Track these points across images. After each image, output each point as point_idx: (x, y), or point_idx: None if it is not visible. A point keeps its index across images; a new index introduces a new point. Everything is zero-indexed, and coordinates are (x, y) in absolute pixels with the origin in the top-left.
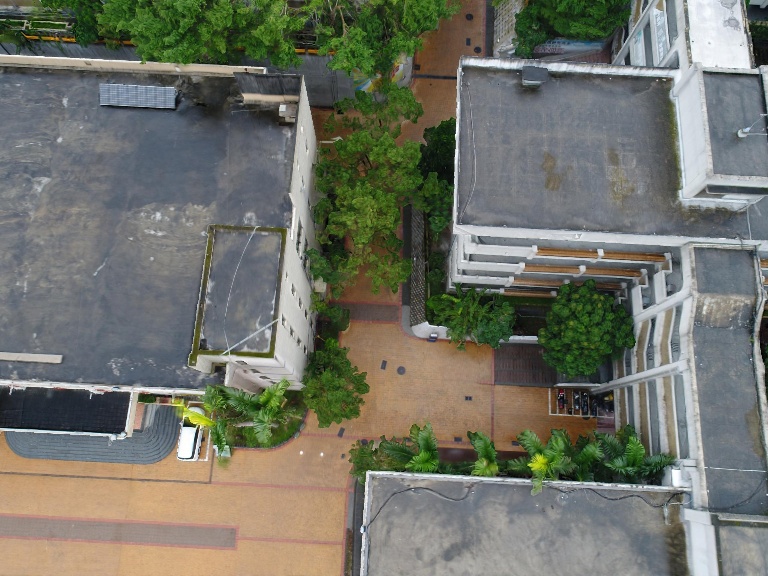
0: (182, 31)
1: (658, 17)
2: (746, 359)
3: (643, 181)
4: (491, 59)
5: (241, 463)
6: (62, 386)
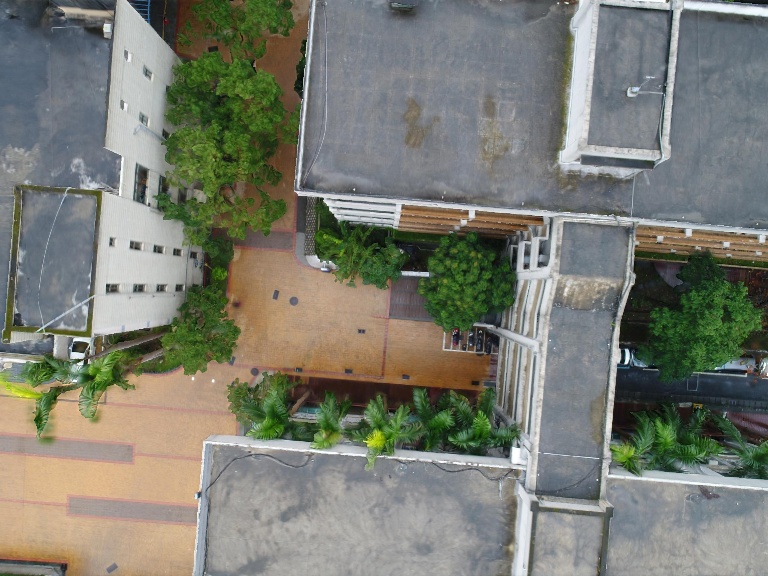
0: None
1: None
2: (604, 344)
3: (520, 138)
4: None
5: None
6: None
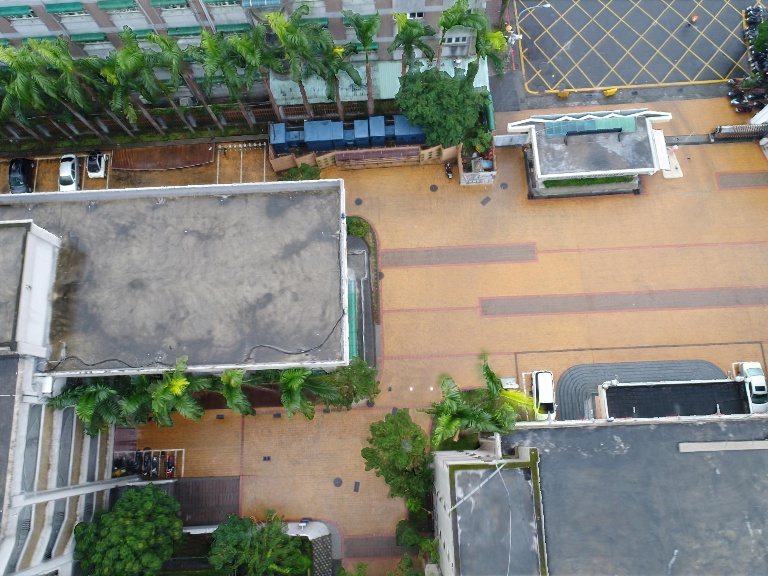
0: None
1: None
2: None
3: None
4: None
5: None
6: (668, 418)
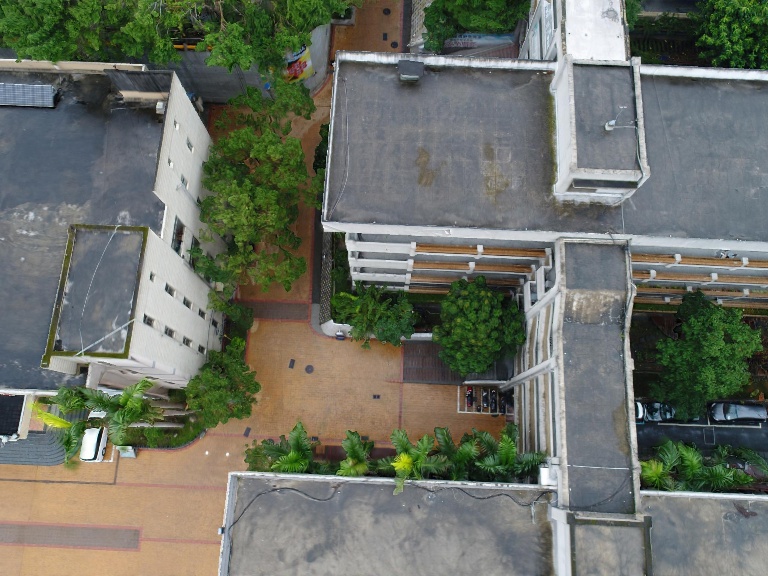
0: (47, 28)
1: (546, 9)
2: (616, 355)
3: (518, 176)
4: (367, 53)
5: (146, 464)
6: None
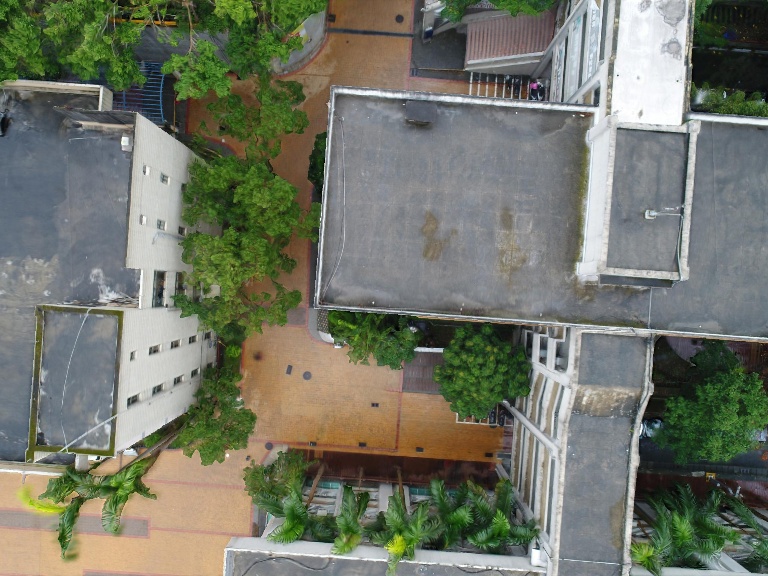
0: None
1: (594, 15)
2: (622, 450)
3: (537, 250)
4: (369, 90)
5: None
6: None
